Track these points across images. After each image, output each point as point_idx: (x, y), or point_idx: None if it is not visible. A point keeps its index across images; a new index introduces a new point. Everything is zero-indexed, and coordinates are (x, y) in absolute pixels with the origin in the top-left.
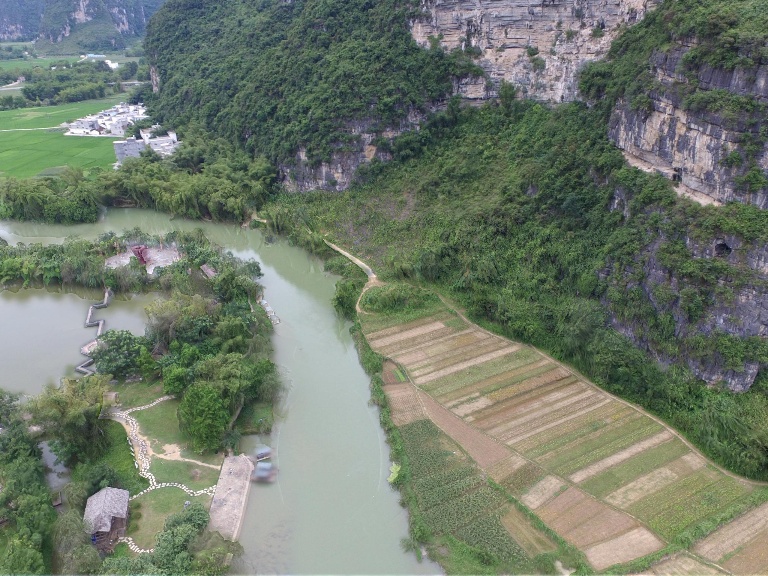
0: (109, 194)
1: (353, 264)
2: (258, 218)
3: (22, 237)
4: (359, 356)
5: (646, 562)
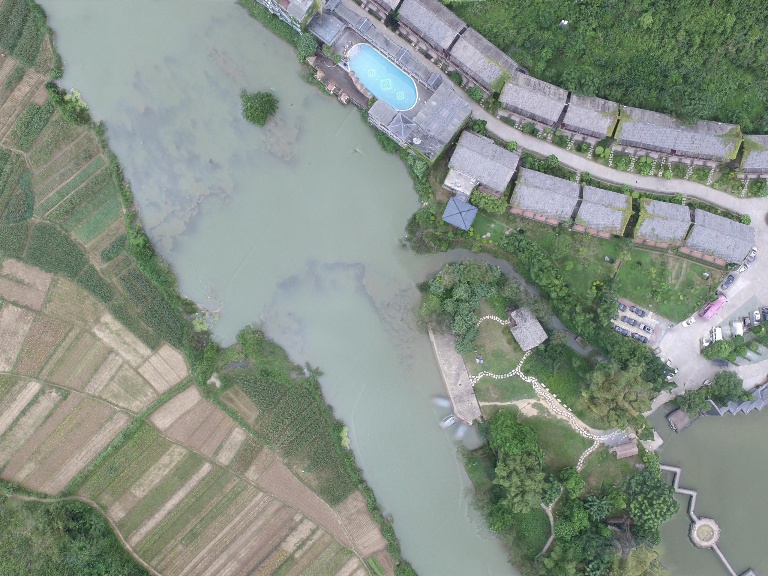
0: None
1: None
2: None
3: None
4: None
5: (163, 398)
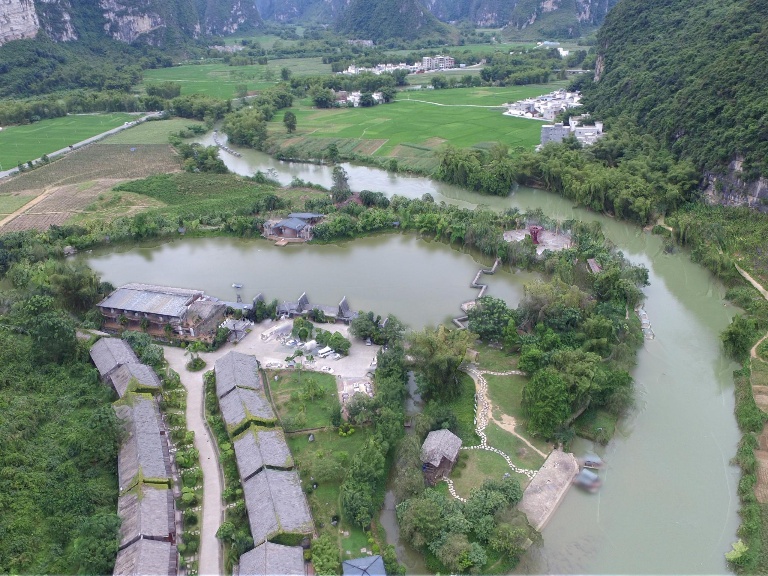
0: (525, 173)
1: (764, 300)
2: (664, 224)
3: (446, 197)
4: (736, 405)
5: None
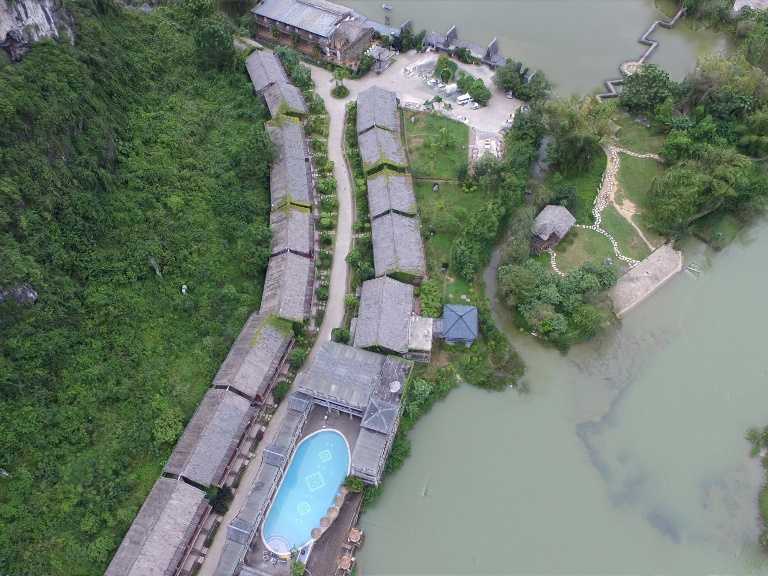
0: None
1: None
2: None
3: None
4: None
5: None
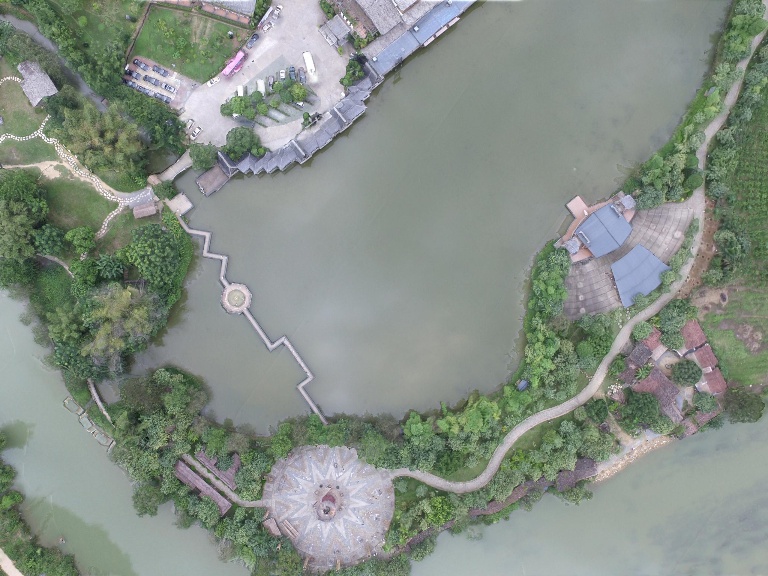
0: None
1: (30, 575)
2: None
3: (610, 561)
4: None
5: None
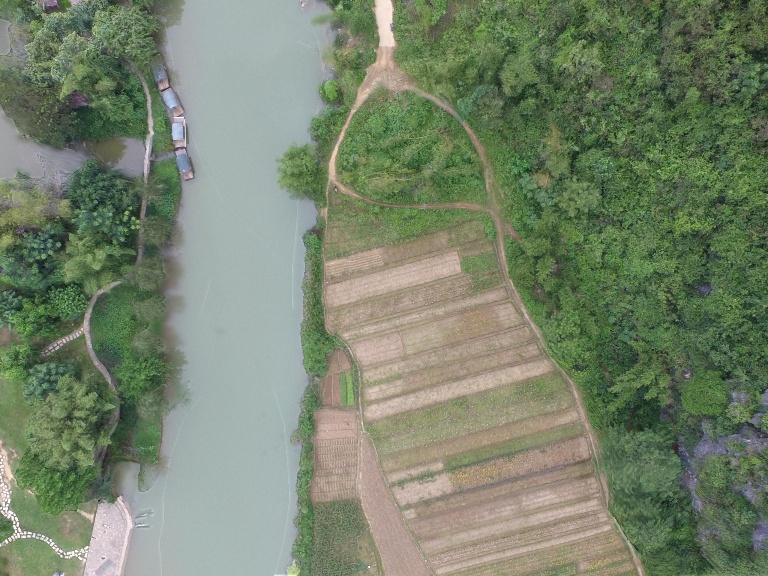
0: None
1: None
2: None
3: None
4: None
5: None
